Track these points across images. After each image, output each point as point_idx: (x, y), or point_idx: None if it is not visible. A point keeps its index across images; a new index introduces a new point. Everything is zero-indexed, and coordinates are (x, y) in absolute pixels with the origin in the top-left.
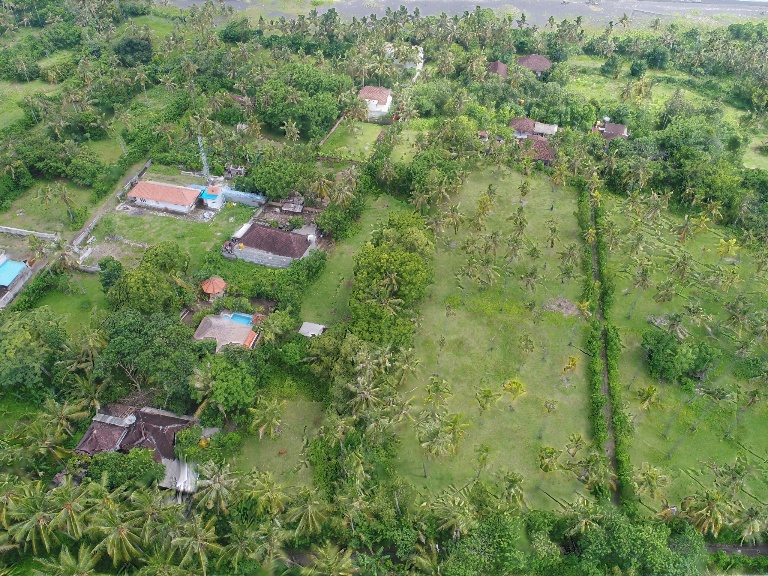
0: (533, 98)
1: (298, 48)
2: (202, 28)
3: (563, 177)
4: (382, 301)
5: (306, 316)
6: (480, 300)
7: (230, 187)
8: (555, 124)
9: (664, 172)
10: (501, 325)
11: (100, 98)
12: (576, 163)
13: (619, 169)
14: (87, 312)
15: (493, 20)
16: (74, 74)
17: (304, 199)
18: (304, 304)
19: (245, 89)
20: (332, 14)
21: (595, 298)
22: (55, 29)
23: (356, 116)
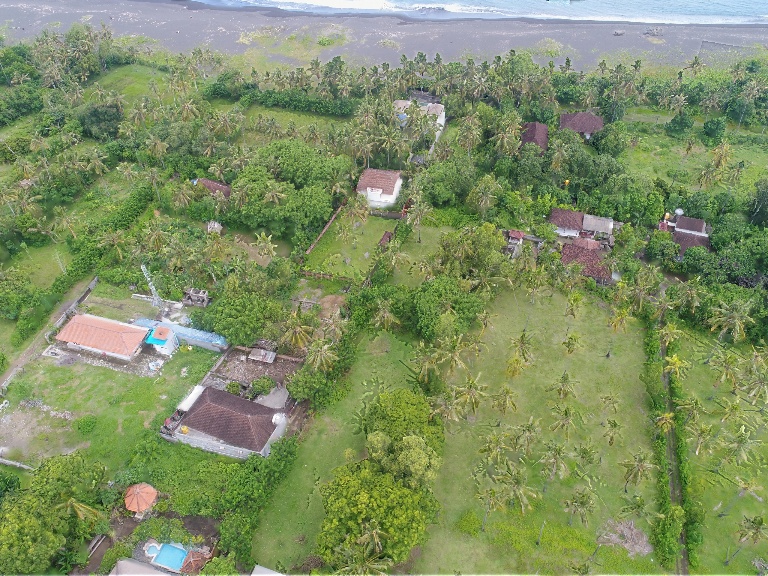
0: (581, 177)
1: (297, 106)
2: (184, 87)
3: (625, 323)
4: (358, 571)
5: (263, 546)
6: (507, 522)
7: (189, 319)
8: (610, 217)
9: (765, 307)
10: (537, 571)
11: (45, 193)
12: (641, 293)
13: (701, 300)
14: None
15: (530, 68)
16: (27, 154)
17: (277, 345)
18: (262, 524)
19: (222, 173)
20: (337, 64)
21: (675, 532)
22: (18, 92)
23: (352, 216)
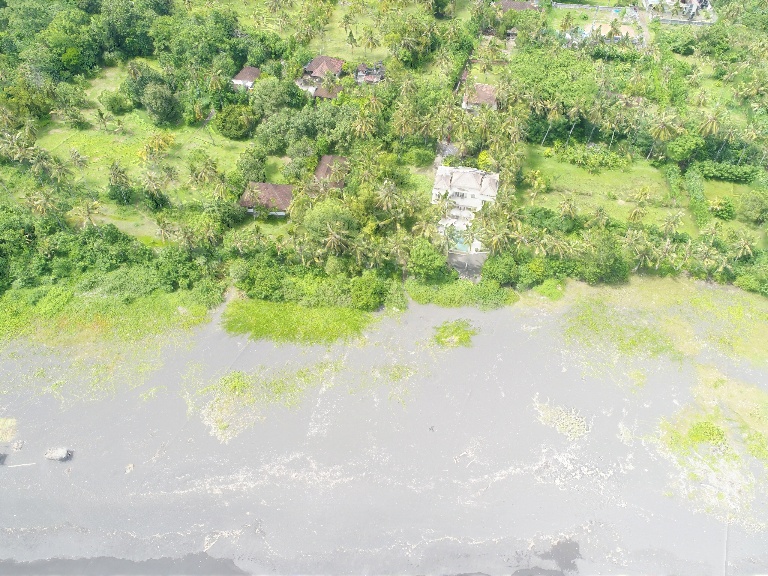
0: None
1: None
2: None
3: None
4: None
5: None
6: (390, 4)
7: None
8: None
9: None
10: None
11: None
12: None
13: None
14: (598, 2)
15: None
16: None
17: None
18: None
19: None
20: None
21: None
22: None
23: None
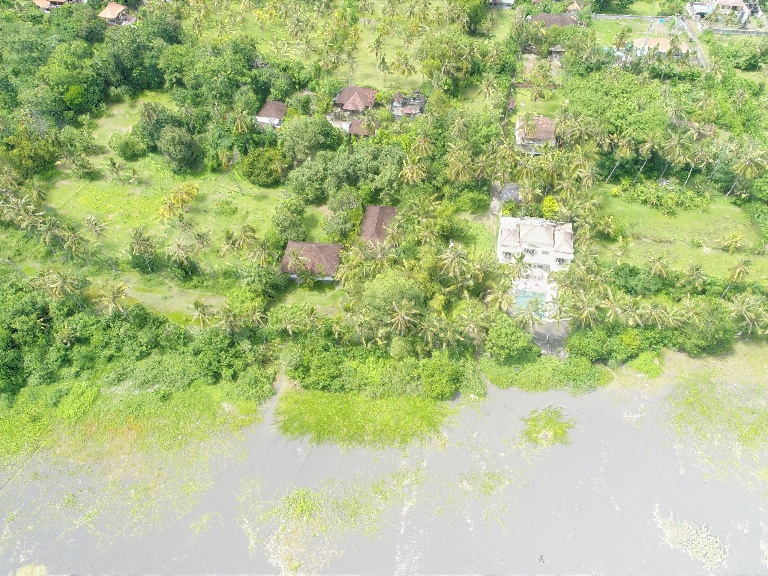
0: None
1: None
2: None
3: None
4: None
5: None
6: None
7: None
8: None
9: (262, 55)
10: None
11: None
12: None
13: None
14: None
15: None
16: None
17: None
18: None
19: None
20: None
21: None
22: None
23: None
